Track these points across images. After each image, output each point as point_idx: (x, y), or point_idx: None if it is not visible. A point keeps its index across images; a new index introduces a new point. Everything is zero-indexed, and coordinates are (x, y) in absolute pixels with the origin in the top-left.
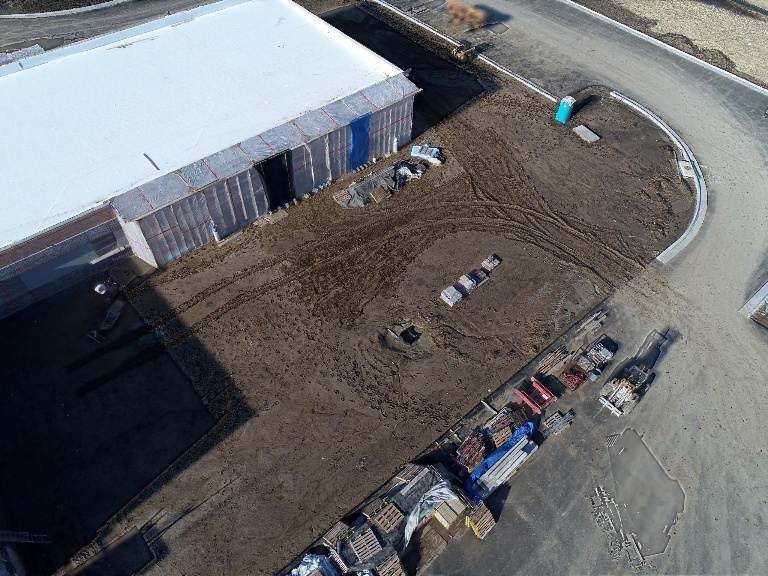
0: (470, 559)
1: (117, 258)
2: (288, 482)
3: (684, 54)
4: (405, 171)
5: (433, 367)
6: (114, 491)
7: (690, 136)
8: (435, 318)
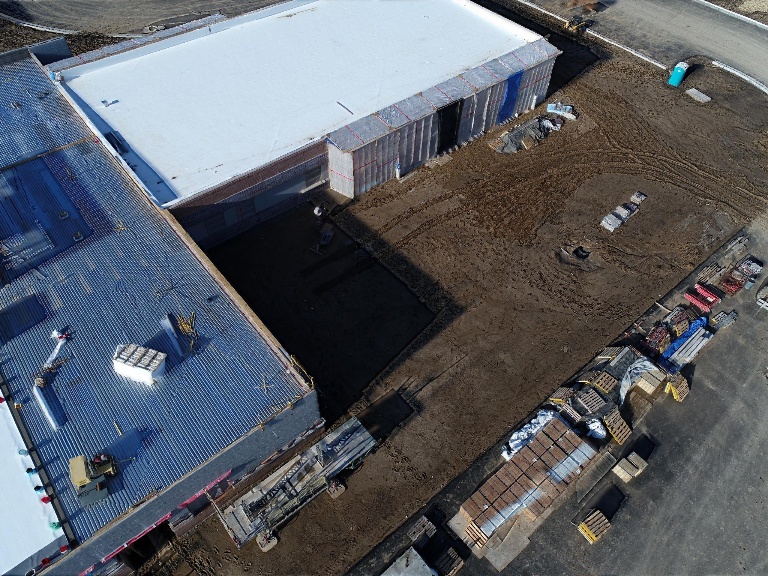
0: (674, 416)
1: (318, 190)
2: (508, 359)
3: None
4: (548, 124)
5: (608, 277)
6: (368, 363)
7: None
8: (600, 240)
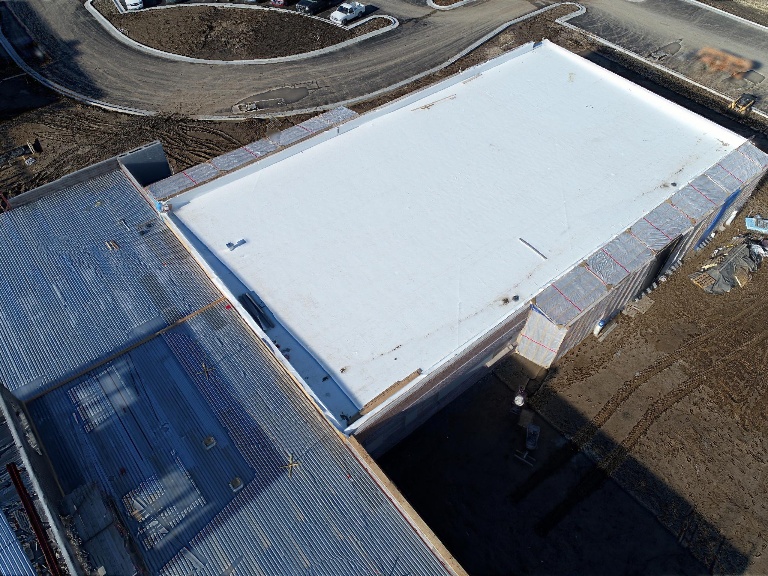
0: None
1: (503, 357)
2: None
3: None
4: (758, 249)
5: None
6: None
7: None
8: None
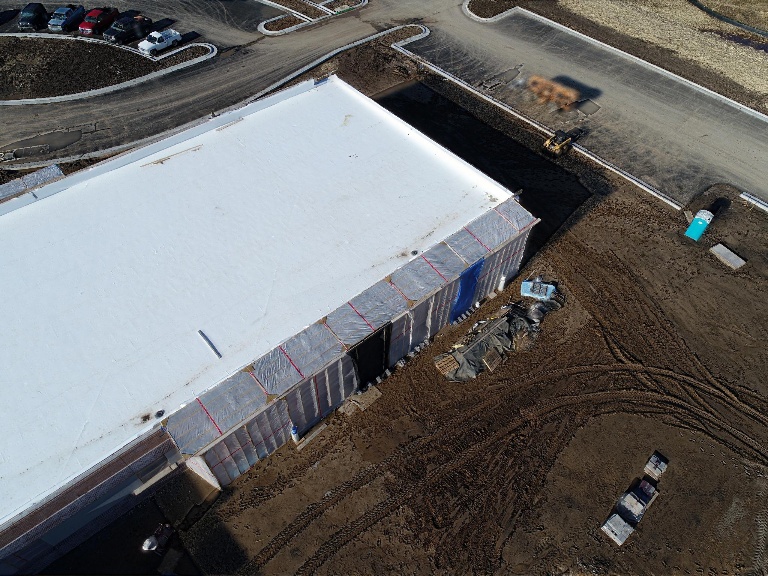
0: None
1: (167, 478)
2: None
3: None
4: (521, 323)
5: None
6: None
7: None
8: (601, 567)
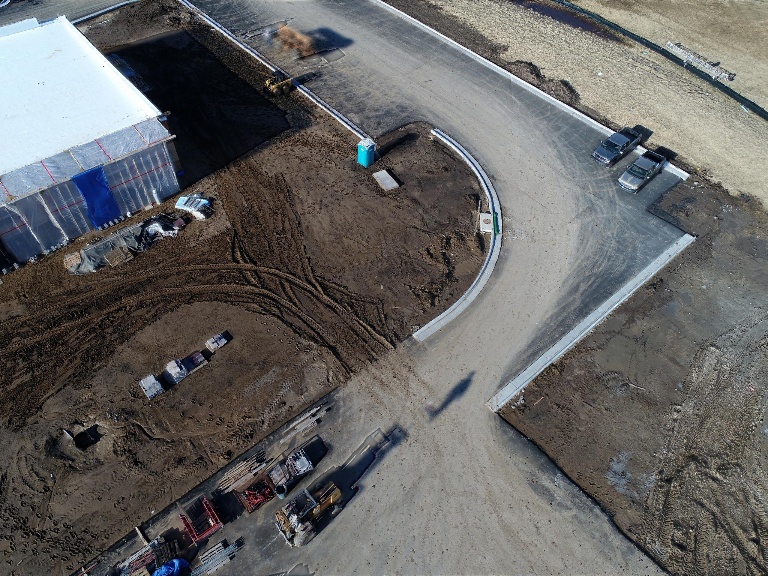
0: None
1: None
2: None
3: (527, 85)
4: (155, 228)
5: (96, 481)
6: None
7: (504, 182)
8: (124, 415)
